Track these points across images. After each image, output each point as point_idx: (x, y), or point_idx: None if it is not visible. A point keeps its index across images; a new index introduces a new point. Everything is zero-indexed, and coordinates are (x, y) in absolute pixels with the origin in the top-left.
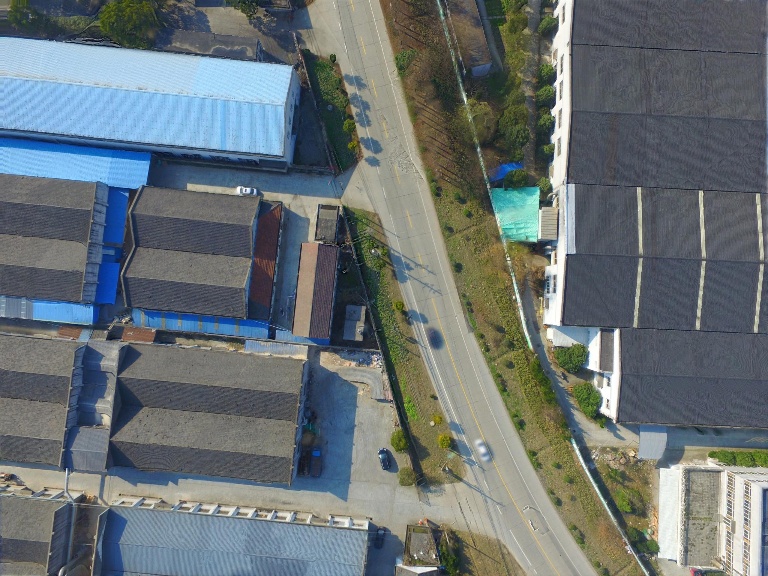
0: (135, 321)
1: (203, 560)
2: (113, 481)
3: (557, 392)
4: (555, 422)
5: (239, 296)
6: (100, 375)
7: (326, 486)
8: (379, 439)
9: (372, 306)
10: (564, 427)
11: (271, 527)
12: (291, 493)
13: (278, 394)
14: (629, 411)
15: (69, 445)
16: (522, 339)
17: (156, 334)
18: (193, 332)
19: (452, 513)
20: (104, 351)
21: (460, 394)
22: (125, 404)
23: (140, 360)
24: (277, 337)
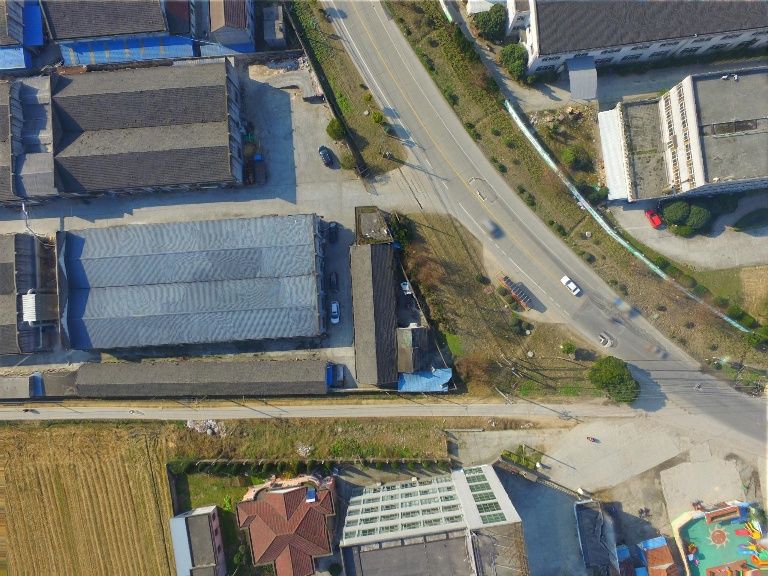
0: (66, 60)
1: (164, 269)
2: (71, 220)
3: (486, 65)
4: (488, 93)
5: (154, 3)
6: (39, 109)
7: (274, 193)
8: (318, 140)
9: (291, 13)
10: (495, 88)
11: (222, 224)
12: (241, 205)
13: (206, 88)
14: (550, 42)
15: (18, 171)
16: (442, 18)
17: (87, 70)
18: (122, 62)
19: (400, 198)
20: (39, 85)
21: (389, 80)
22: (66, 131)
23: (72, 84)
24: (202, 53)
